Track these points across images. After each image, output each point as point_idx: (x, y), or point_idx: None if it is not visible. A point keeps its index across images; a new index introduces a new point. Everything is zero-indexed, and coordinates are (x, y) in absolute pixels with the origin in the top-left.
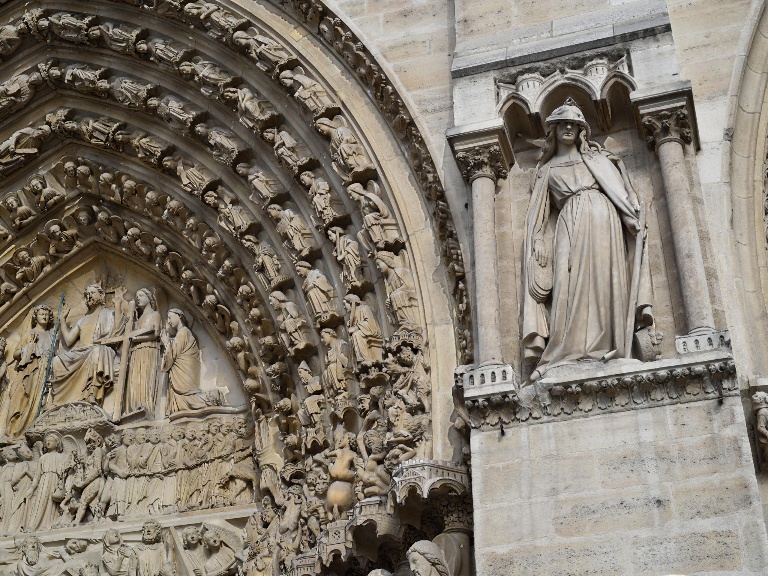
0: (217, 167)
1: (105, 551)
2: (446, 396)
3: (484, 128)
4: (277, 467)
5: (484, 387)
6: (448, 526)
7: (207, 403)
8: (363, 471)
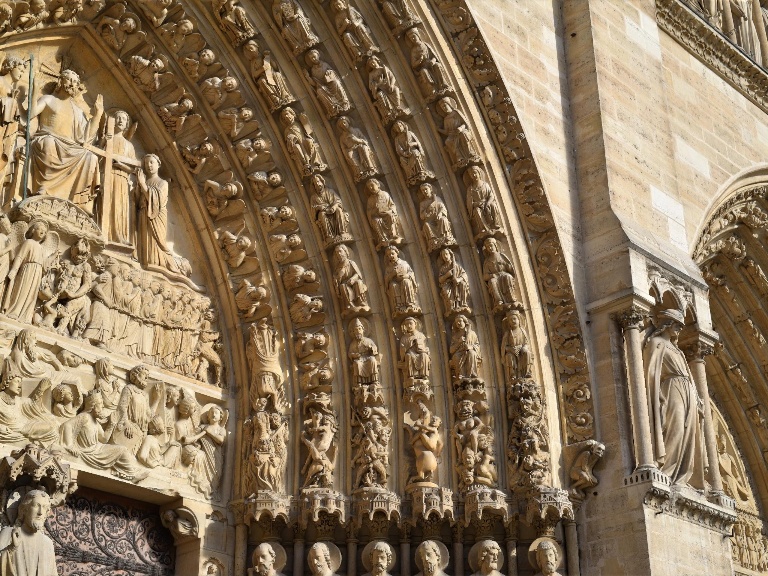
0: (302, 90)
1: (100, 377)
2: (556, 445)
3: (649, 300)
4: (281, 379)
5: (660, 484)
6: (550, 534)
7: (182, 271)
8: (474, 461)
